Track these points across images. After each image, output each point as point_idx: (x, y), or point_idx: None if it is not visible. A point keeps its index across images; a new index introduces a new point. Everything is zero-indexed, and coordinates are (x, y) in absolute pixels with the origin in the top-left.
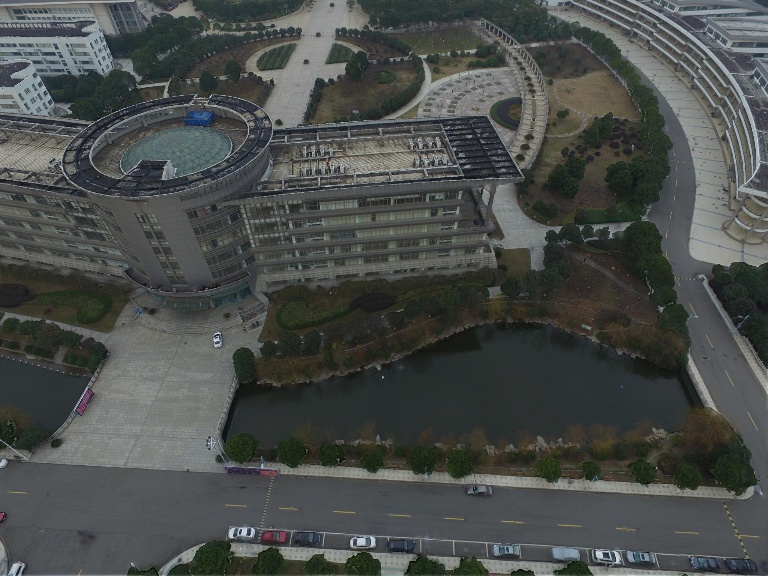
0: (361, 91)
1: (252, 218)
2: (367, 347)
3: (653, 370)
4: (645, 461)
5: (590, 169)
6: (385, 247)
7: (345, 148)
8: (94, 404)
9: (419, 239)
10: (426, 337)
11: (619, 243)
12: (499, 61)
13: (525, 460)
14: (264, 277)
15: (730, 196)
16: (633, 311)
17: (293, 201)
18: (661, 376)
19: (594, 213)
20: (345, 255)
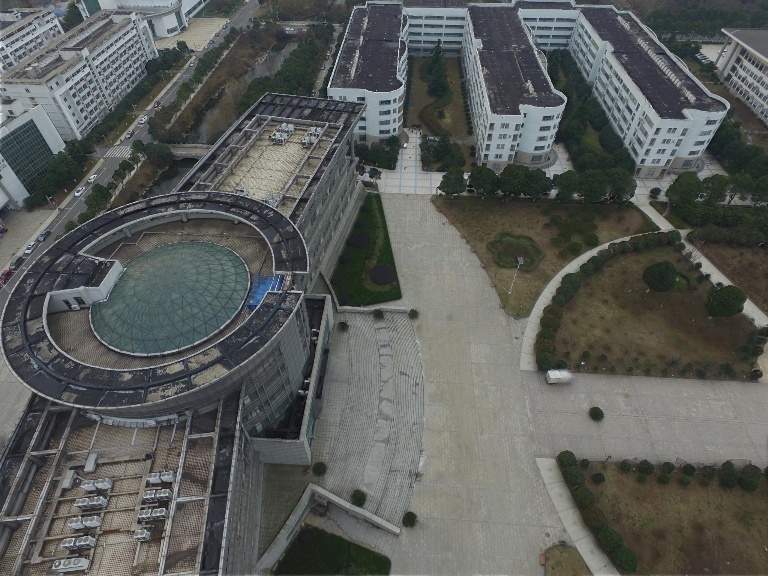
0: None
1: None
2: None
3: None
4: None
5: None
6: None
7: (171, 568)
8: None
9: None
10: None
11: None
12: None
13: None
14: None
15: None
16: None
17: None
18: None
19: None
20: None
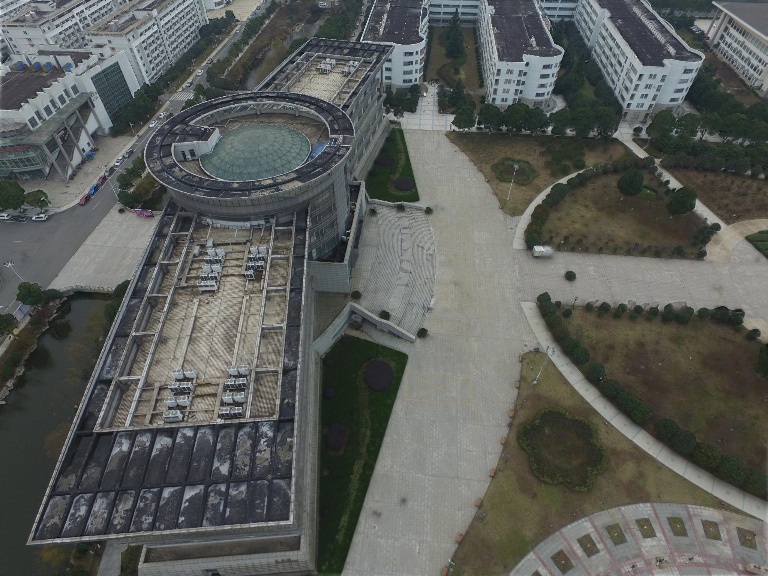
0: (742, 388)
1: None
2: None
3: None
4: None
5: None
6: None
7: None
8: (145, 219)
9: None
10: None
11: None
12: None
13: None
14: None
15: None
16: None
17: None
18: None
19: None
20: None
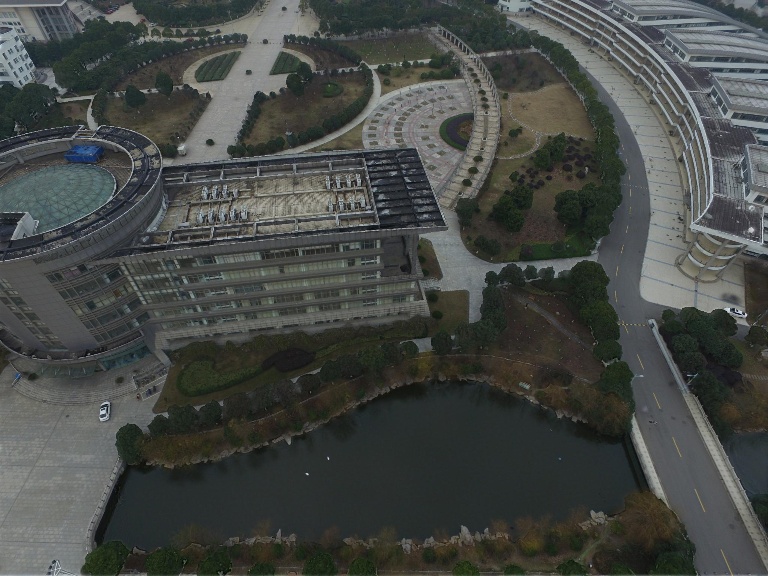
0: (304, 106)
1: (136, 275)
2: (277, 416)
3: (595, 436)
4: (576, 563)
5: (540, 195)
6: (301, 299)
7: (254, 187)
8: None
9: (338, 289)
10: (346, 402)
11: (565, 283)
12: (453, 72)
13: (443, 560)
14: (164, 334)
15: (685, 226)
16: (576, 365)
17: (182, 256)
18: (605, 441)
19: (541, 248)
20: (255, 309)
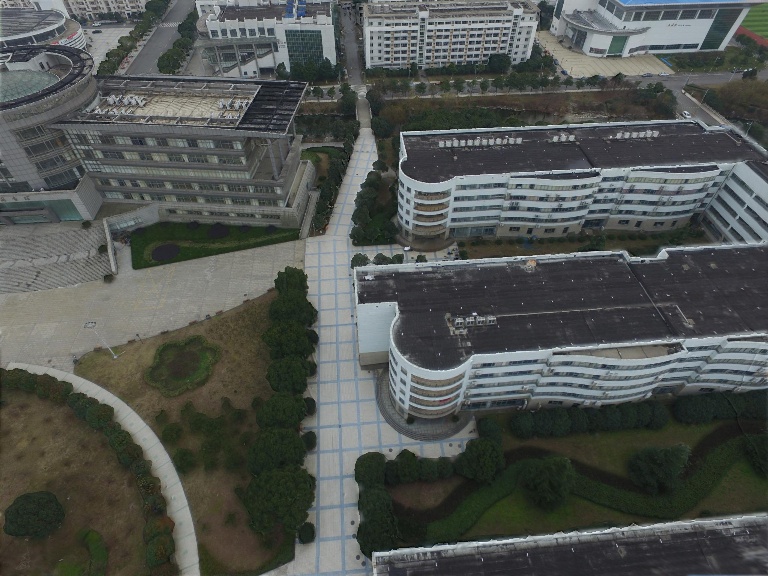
0: None
1: None
2: None
3: None
4: None
5: None
6: None
7: None
8: None
9: None
10: None
11: None
12: None
13: None
14: None
15: None
16: None
17: None
18: None
19: None
20: None
